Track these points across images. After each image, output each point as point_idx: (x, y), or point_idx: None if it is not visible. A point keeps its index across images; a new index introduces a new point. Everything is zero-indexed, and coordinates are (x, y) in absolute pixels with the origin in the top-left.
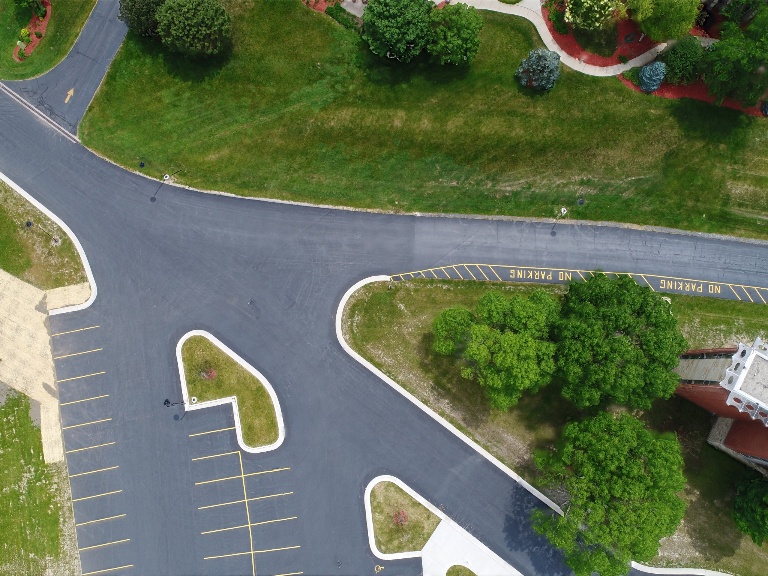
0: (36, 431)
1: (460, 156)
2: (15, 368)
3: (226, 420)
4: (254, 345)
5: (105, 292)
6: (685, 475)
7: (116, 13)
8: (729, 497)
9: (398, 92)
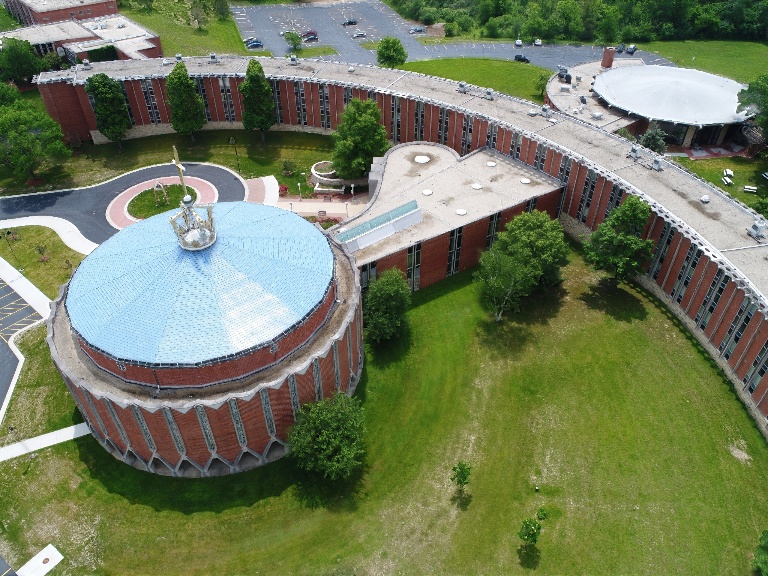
0: None
1: None
2: None
3: None
4: None
5: None
6: (93, 157)
7: None
8: (120, 151)
9: None
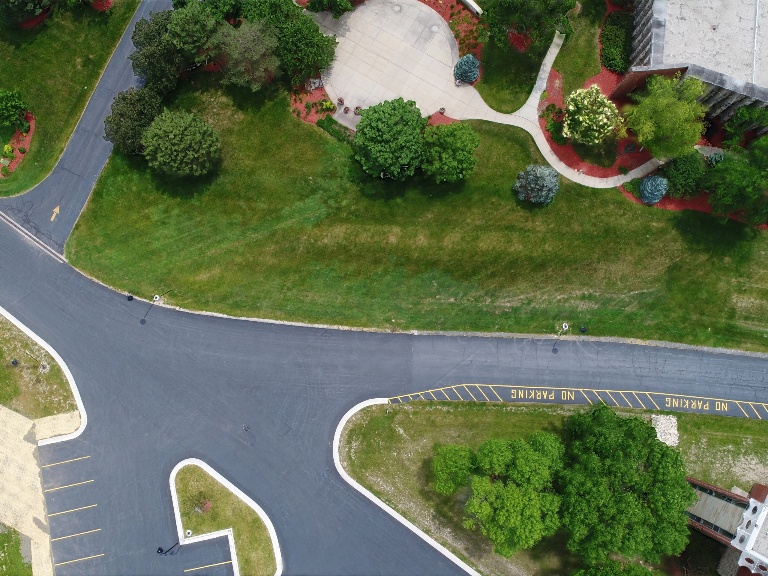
0: (27, 568)
1: (458, 272)
2: (4, 502)
3: (222, 554)
4: (249, 474)
5: (95, 420)
6: None
7: (102, 127)
8: None
9: (393, 207)
